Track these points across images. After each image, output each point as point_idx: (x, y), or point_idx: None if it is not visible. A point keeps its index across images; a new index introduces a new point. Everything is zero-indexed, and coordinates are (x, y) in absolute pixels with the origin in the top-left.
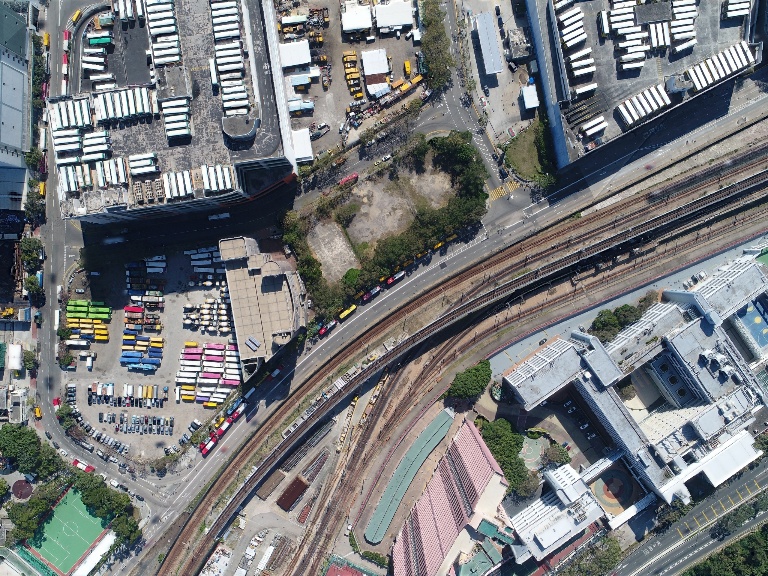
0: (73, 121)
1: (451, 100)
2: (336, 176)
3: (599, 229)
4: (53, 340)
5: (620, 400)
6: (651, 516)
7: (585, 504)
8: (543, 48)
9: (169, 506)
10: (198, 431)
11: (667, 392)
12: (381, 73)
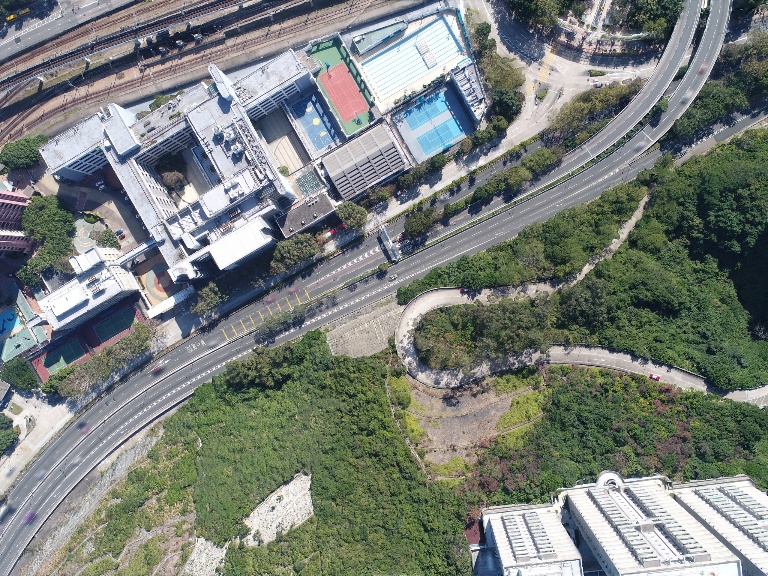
0: None
1: None
2: None
3: (167, 15)
4: None
5: (138, 173)
6: None
7: (103, 278)
8: None
9: None
10: None
11: (206, 180)
12: None
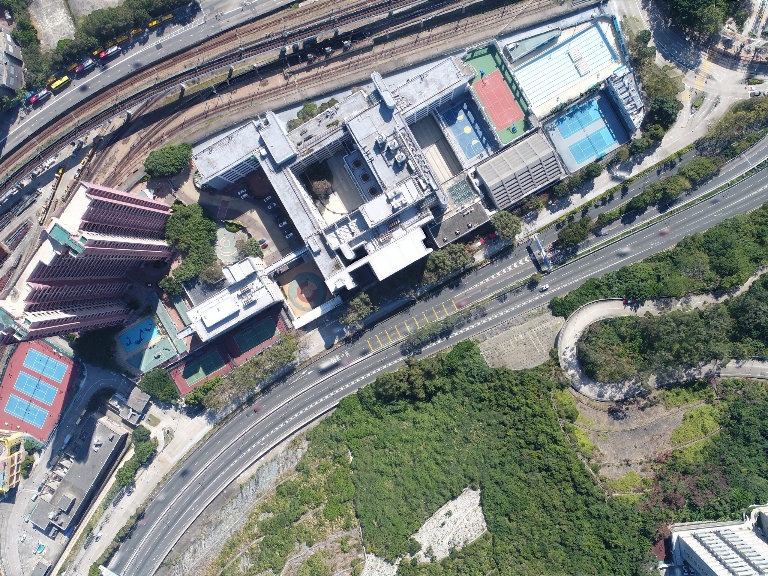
0: None
1: None
2: None
3: (314, 21)
4: None
5: (295, 182)
6: (342, 325)
7: (255, 289)
8: None
9: None
10: None
11: None
12: None
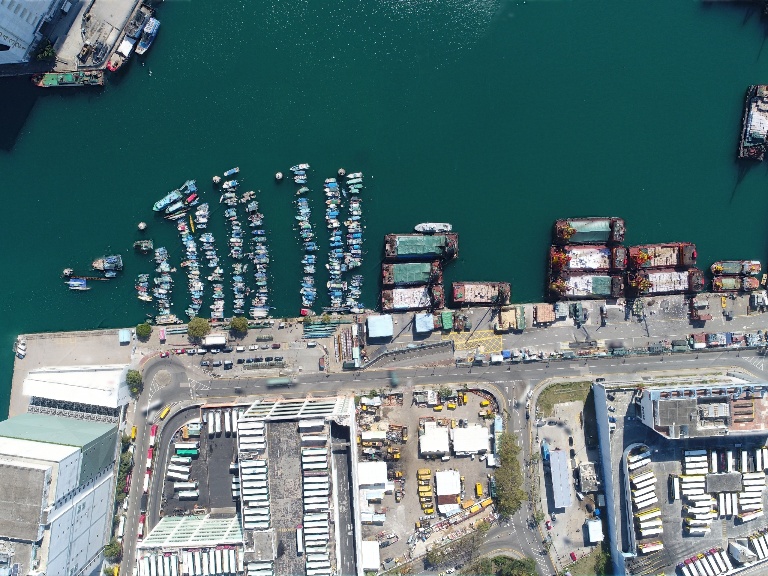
0: (161, 575)
1: (518, 521)
2: None
3: None
4: None
5: None
6: None
7: None
8: (613, 498)
9: None
10: None
11: None
12: (453, 494)
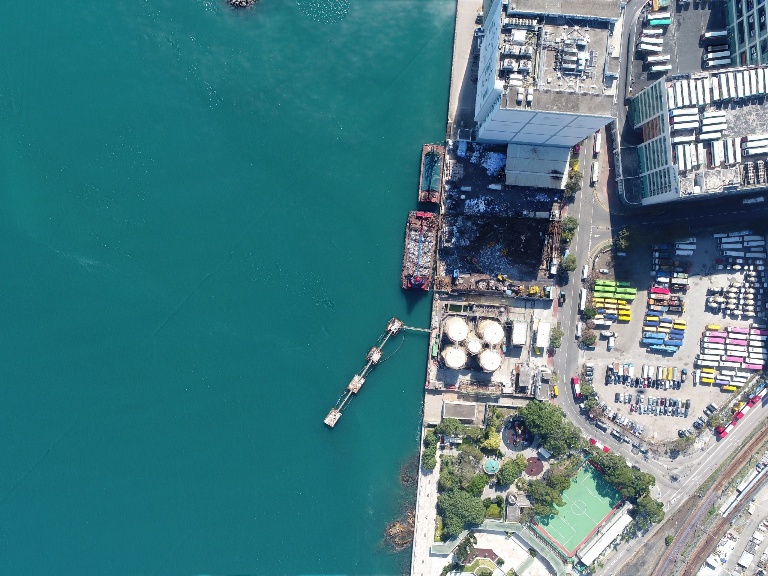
0: (695, 100)
1: None
2: None
3: None
4: (573, 319)
5: None
6: None
7: None
8: None
9: (679, 488)
10: (716, 414)
11: None
12: None
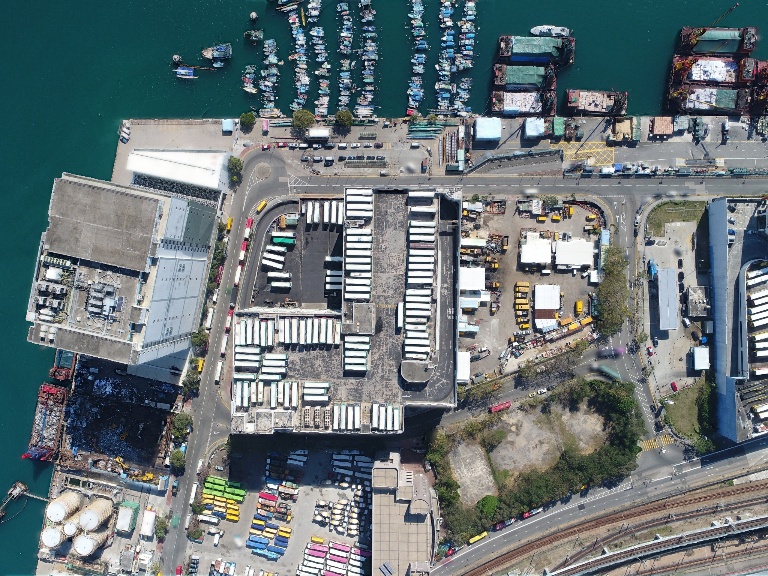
0: (257, 340)
1: (617, 345)
2: (488, 400)
3: (750, 501)
4: (185, 510)
5: None
6: None
7: None
8: (726, 318)
9: None
10: None
11: None
12: (552, 309)
